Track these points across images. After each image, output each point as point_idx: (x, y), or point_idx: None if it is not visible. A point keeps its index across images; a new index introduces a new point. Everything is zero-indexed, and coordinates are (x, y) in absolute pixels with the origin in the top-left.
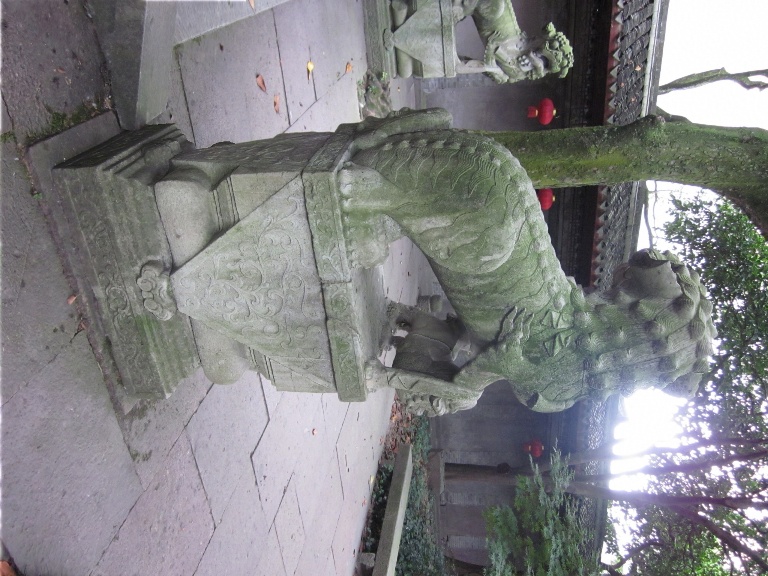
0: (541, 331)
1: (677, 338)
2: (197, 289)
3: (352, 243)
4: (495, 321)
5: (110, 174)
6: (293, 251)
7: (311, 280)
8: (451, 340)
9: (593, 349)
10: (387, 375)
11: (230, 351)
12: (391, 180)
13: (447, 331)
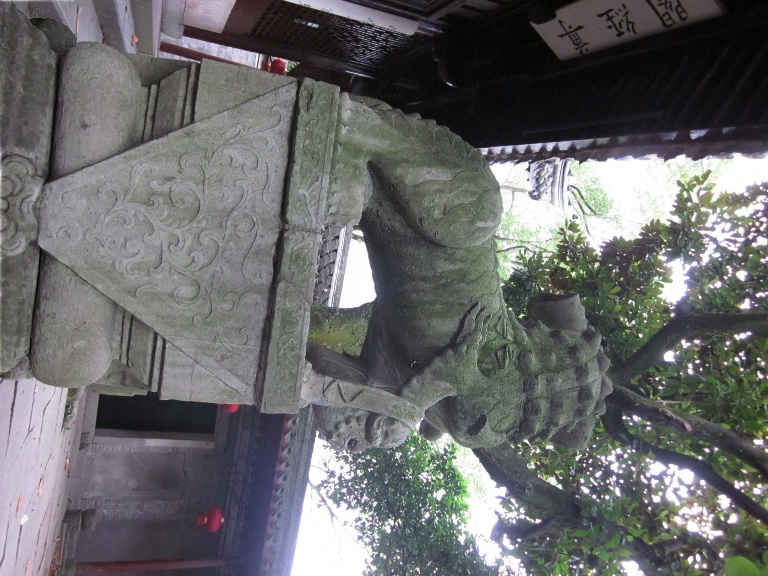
0: (494, 338)
1: (592, 367)
2: (86, 213)
3: (337, 182)
4: (455, 319)
5: (8, 4)
6: (256, 180)
7: (269, 224)
8: (363, 371)
9: (533, 368)
10: (324, 381)
11: (99, 327)
12: (388, 123)
13: (355, 363)
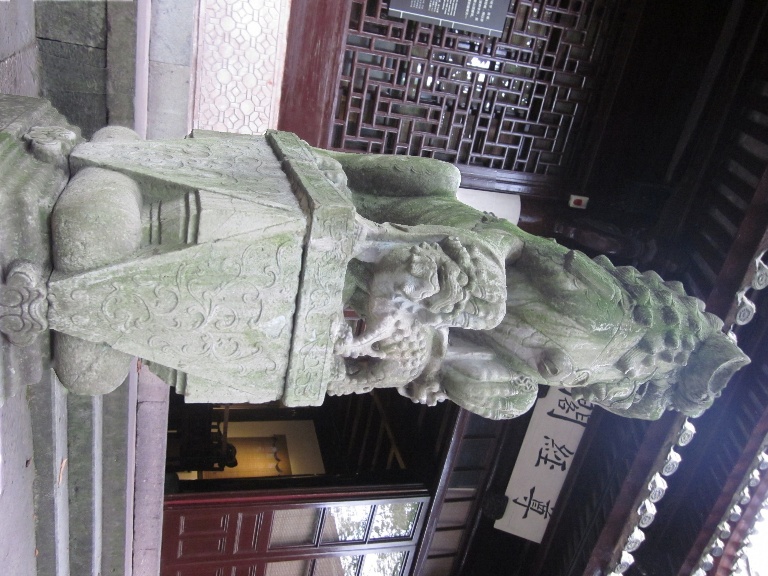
0: None
1: None
2: (113, 151)
3: None
4: (475, 221)
5: None
6: None
7: (270, 161)
8: None
9: None
10: (374, 223)
11: (129, 189)
12: None
13: None
